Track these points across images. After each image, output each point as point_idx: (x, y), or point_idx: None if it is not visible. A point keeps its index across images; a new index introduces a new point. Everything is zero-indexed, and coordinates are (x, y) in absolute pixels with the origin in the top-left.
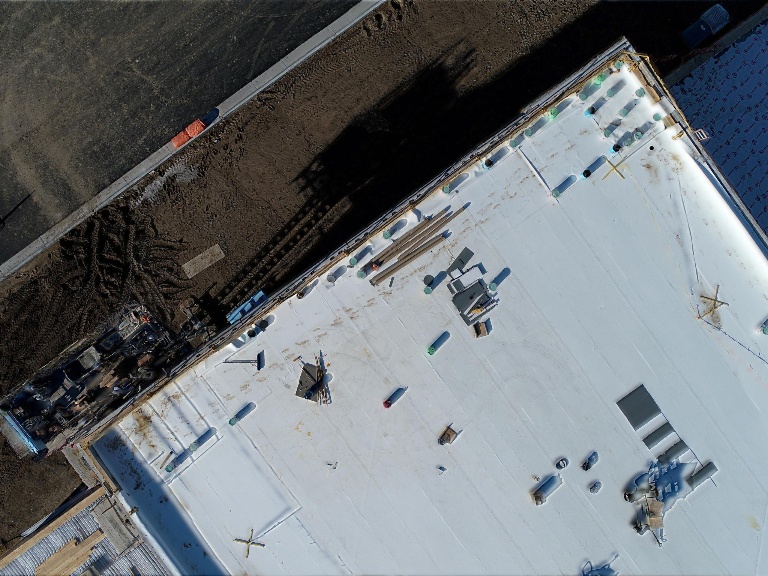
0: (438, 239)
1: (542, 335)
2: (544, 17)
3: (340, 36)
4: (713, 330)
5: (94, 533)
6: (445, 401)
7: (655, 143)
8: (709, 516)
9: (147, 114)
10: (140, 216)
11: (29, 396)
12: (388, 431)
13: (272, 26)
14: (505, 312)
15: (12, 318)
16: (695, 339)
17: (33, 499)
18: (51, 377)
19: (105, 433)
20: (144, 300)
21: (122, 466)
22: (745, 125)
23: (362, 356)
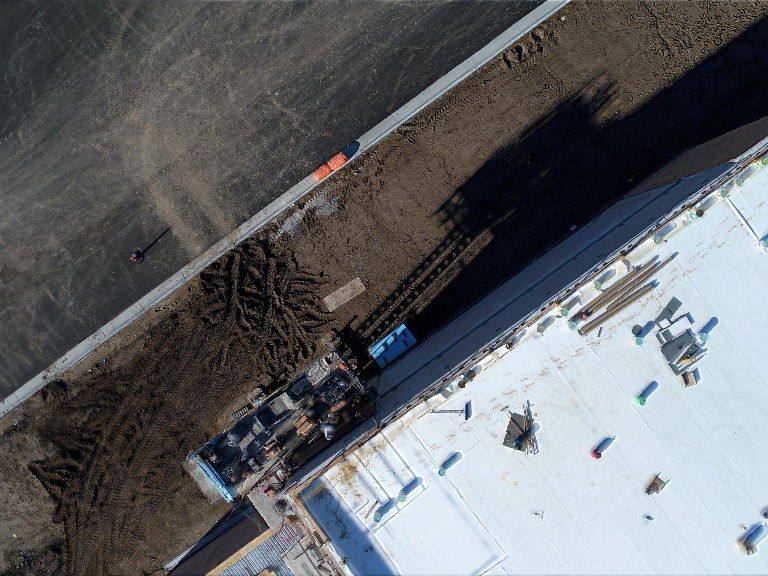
0: (647, 289)
1: (750, 384)
2: (687, 49)
3: (480, 68)
4: None
5: (262, 572)
6: (653, 451)
7: None
8: None
9: (287, 147)
10: (280, 249)
11: (223, 443)
12: (595, 481)
13: (412, 58)
14: (713, 361)
15: (153, 351)
16: None
17: (175, 532)
18: (242, 423)
19: (311, 483)
20: (285, 333)
21: (328, 515)
22: None
23: (569, 406)
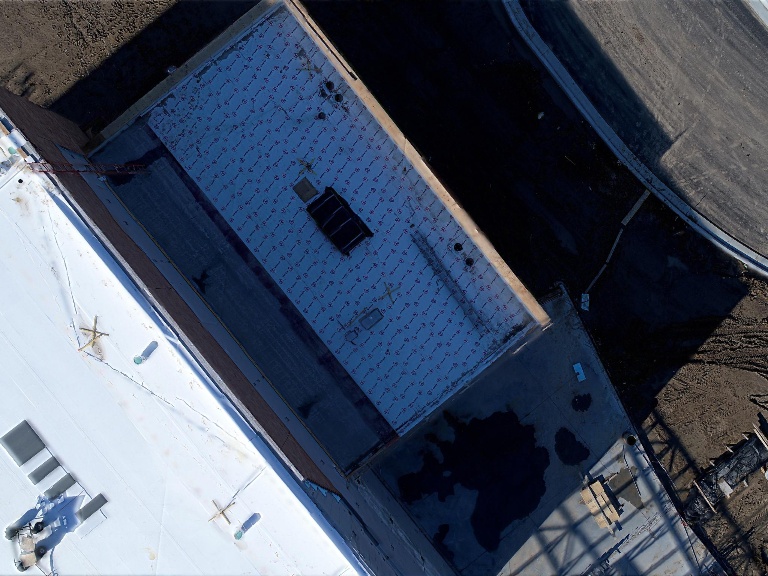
0: None
1: None
2: (101, 37)
3: None
4: (94, 361)
5: None
6: None
7: (23, 176)
8: (101, 548)
9: None
10: None
11: None
12: None
13: None
14: None
15: None
16: (77, 371)
17: None
18: None
19: None
20: None
21: None
22: (232, 143)
23: None
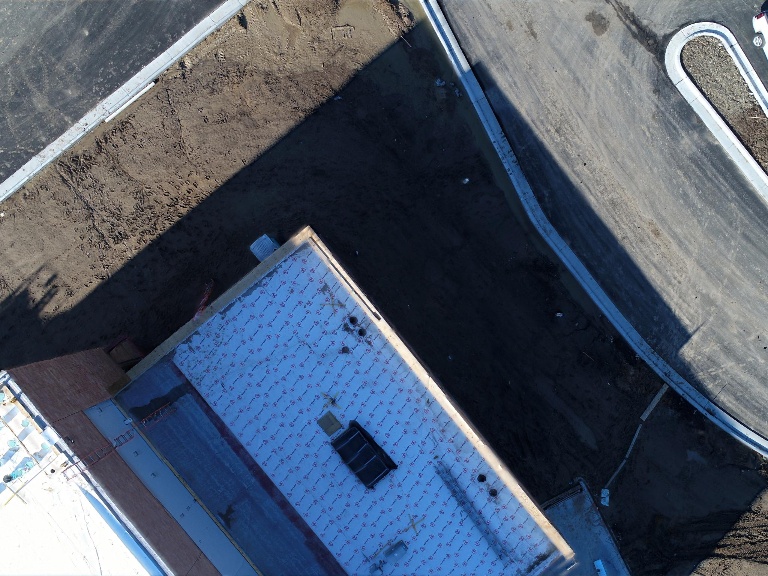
0: None
1: None
2: (122, 240)
3: None
4: None
5: None
6: None
7: (55, 466)
8: None
9: None
10: None
11: None
12: None
13: None
14: None
15: None
16: None
17: None
18: None
19: None
20: None
21: None
22: (256, 378)
23: None
